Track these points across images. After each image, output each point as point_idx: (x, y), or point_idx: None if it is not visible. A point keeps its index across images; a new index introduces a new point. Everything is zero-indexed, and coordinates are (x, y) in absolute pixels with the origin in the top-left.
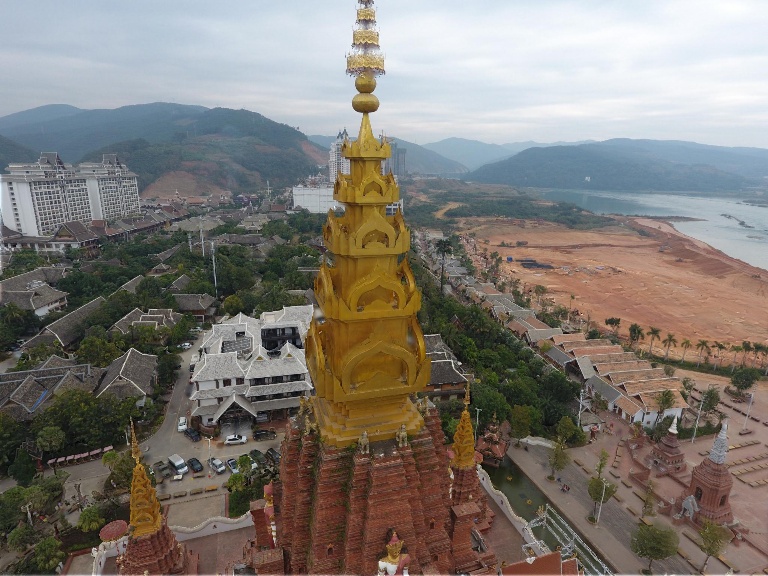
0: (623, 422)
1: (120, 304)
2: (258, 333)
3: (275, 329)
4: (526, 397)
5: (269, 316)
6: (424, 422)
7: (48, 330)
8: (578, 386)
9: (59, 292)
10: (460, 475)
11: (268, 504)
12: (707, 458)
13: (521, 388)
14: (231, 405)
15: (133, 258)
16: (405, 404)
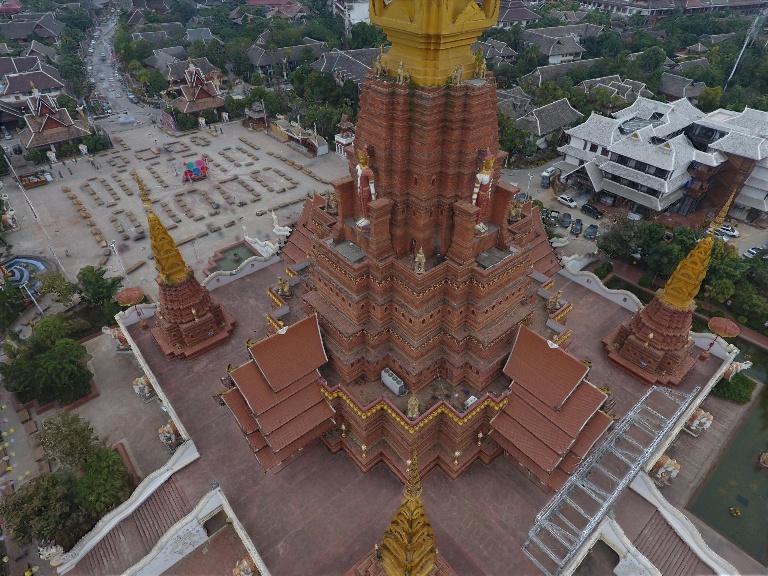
0: None
1: (606, 66)
2: (681, 123)
3: (713, 130)
4: None
5: (722, 115)
6: (438, 82)
7: (538, 71)
8: None
9: (578, 46)
10: (657, 307)
11: None
12: None
13: None
14: (581, 168)
15: (681, 34)
16: (437, 61)
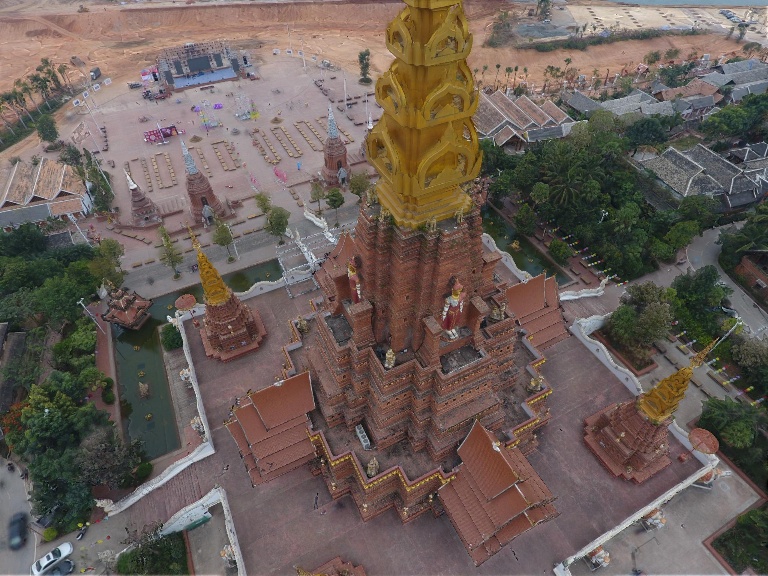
0: (81, 222)
1: None
2: None
3: None
4: (44, 268)
5: None
6: None
7: None
8: (31, 225)
9: None
10: (232, 302)
11: (458, 296)
12: (188, 176)
13: (25, 267)
14: None
15: None
16: None
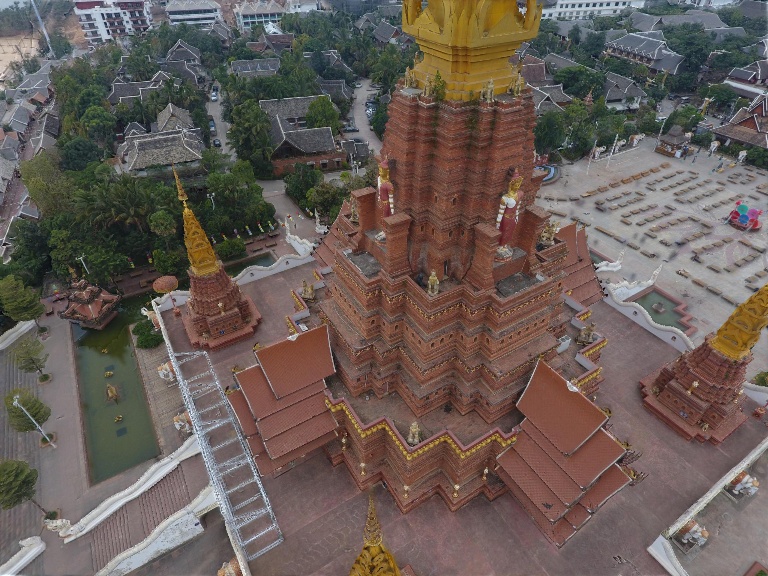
0: None
1: None
2: None
3: None
4: None
5: None
6: None
7: None
8: None
9: None
10: None
11: None
12: None
13: None
14: None
15: None
16: None
